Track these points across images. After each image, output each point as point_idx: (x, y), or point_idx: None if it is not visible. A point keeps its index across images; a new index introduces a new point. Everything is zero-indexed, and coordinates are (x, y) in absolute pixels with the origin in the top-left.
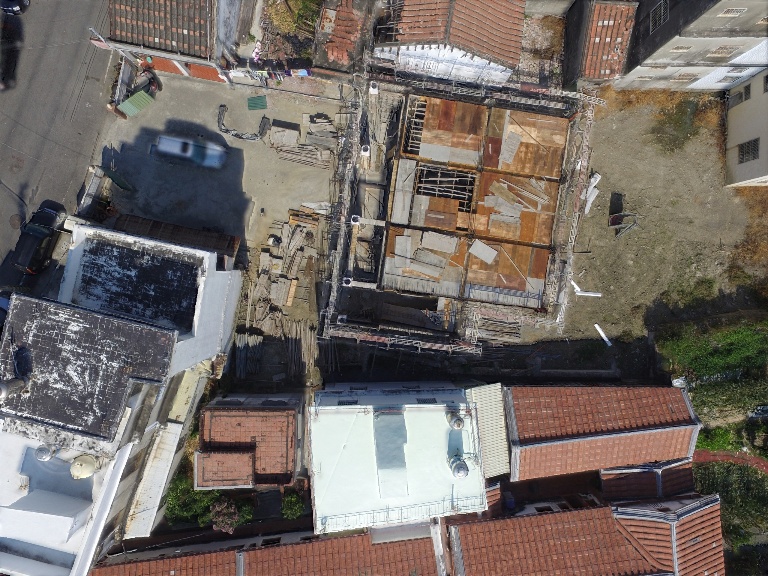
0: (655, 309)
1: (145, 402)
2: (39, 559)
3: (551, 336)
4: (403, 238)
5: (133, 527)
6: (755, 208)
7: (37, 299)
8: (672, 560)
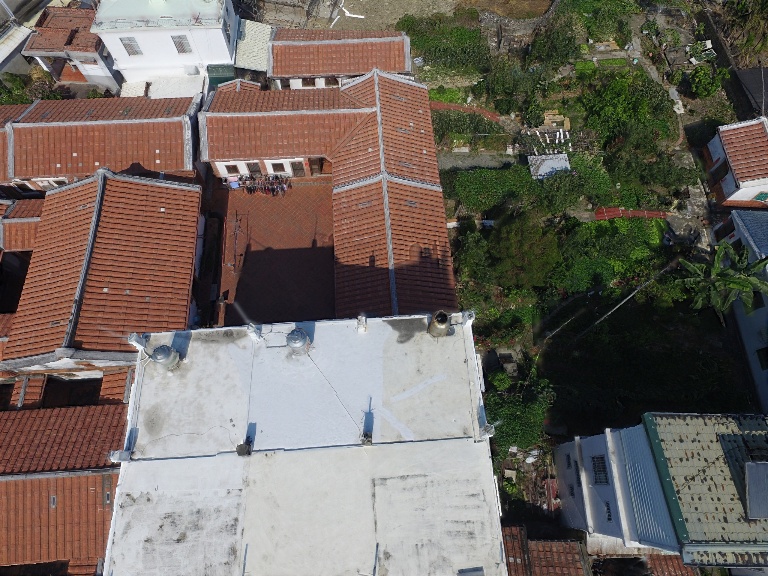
0: None
1: None
2: None
3: None
4: None
5: None
6: None
7: None
8: (375, 98)
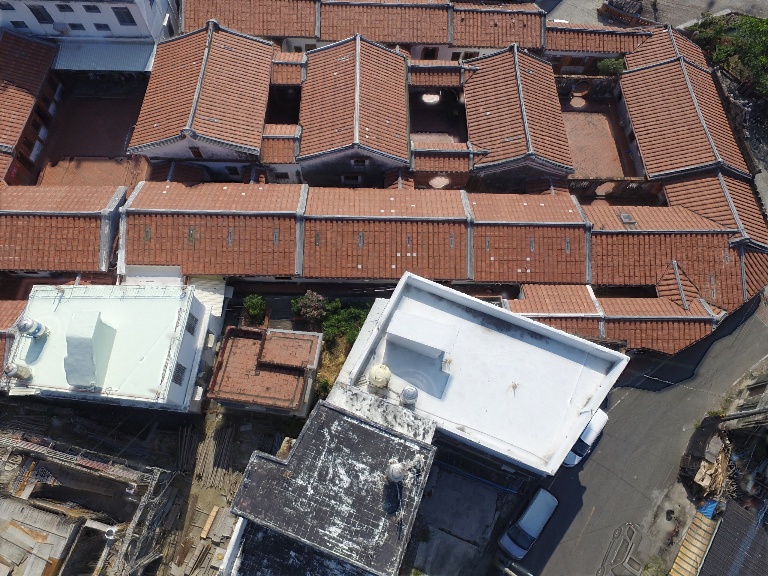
0: None
1: None
2: (439, 298)
3: None
4: None
5: None
6: None
7: (369, 571)
8: None
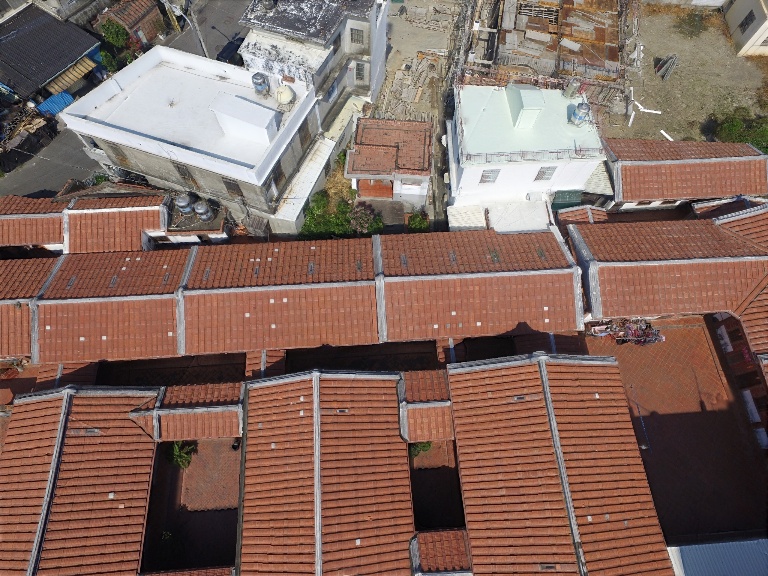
0: (707, 124)
1: (330, 75)
2: None
3: (626, 136)
4: (511, 35)
5: (284, 209)
6: (765, 68)
7: None
8: None
